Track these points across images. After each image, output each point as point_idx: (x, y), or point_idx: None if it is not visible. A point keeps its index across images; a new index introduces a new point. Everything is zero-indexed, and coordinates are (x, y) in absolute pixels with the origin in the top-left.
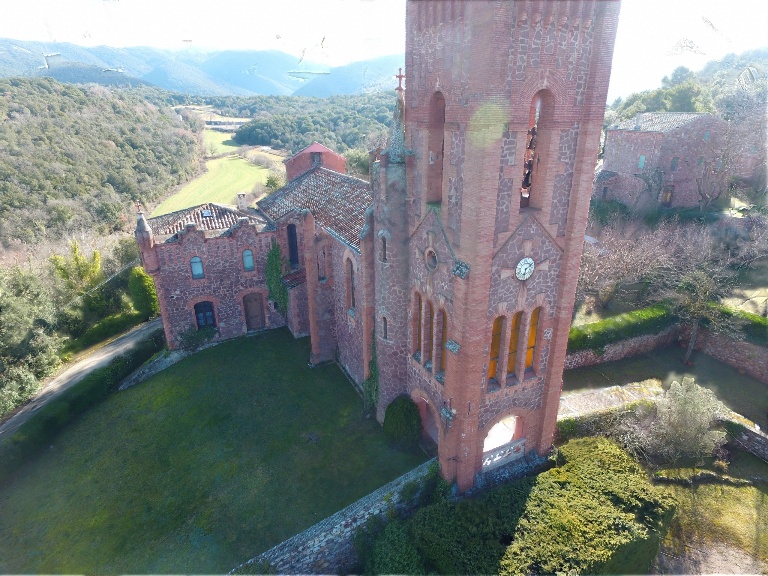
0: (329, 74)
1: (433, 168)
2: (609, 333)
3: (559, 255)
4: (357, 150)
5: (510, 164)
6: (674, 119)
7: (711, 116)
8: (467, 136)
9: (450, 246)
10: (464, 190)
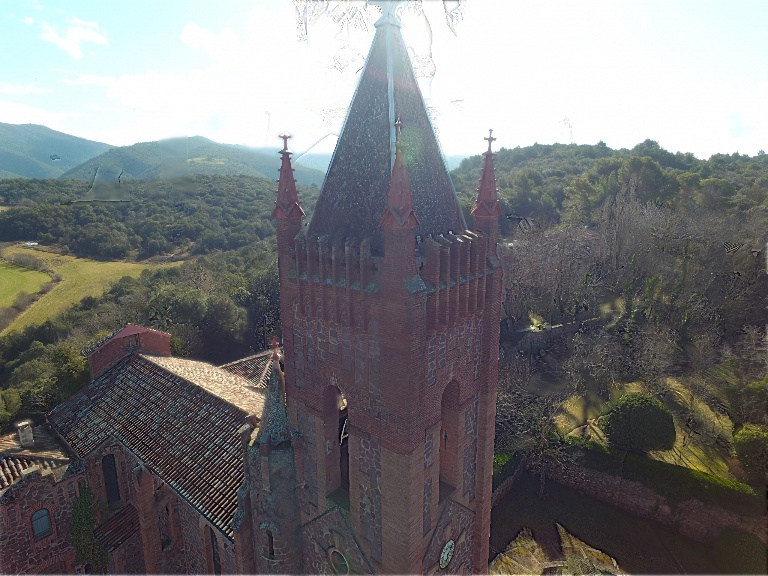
0: (127, 202)
1: (331, 457)
2: None
3: (472, 518)
4: (171, 288)
5: (428, 465)
6: None
7: (501, 246)
8: (383, 452)
9: (367, 559)
10: (384, 507)
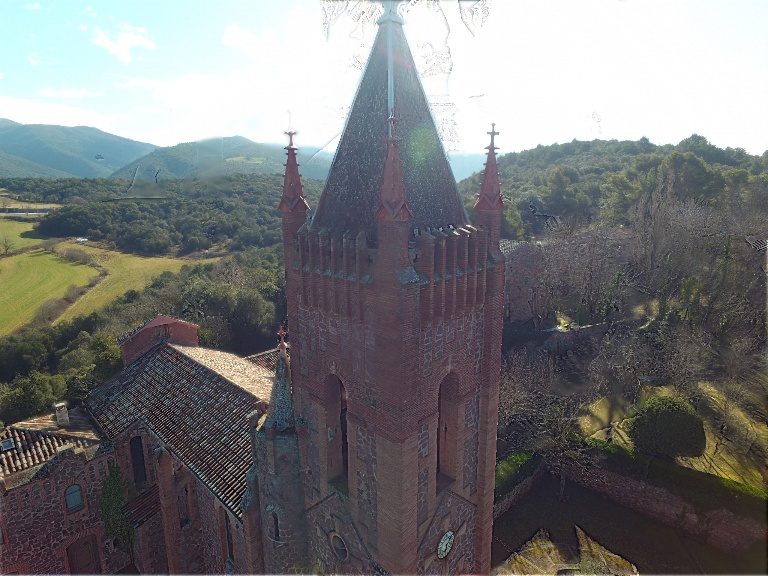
0: (164, 199)
1: (332, 444)
2: (496, 492)
3: (473, 511)
4: (203, 282)
5: (424, 455)
6: (501, 246)
7: (528, 245)
8: (378, 440)
9: (364, 544)
10: (379, 494)
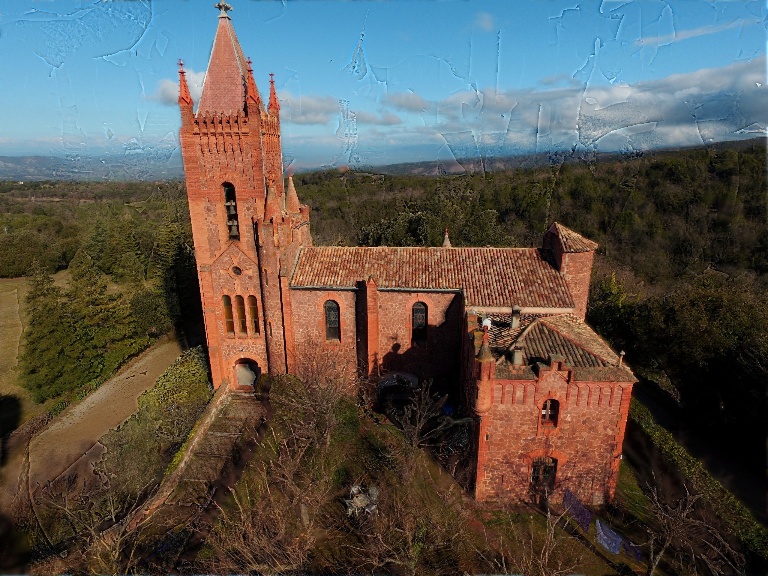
0: None
1: None
2: None
3: None
4: None
5: None
6: None
7: None
8: None
9: None
10: None
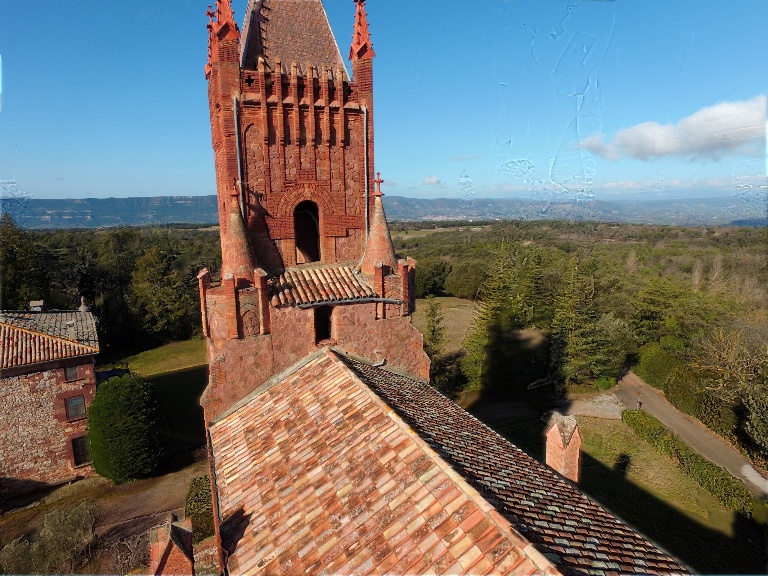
0: None
1: None
2: None
3: None
4: None
5: None
6: None
7: None
8: None
9: None
10: None
